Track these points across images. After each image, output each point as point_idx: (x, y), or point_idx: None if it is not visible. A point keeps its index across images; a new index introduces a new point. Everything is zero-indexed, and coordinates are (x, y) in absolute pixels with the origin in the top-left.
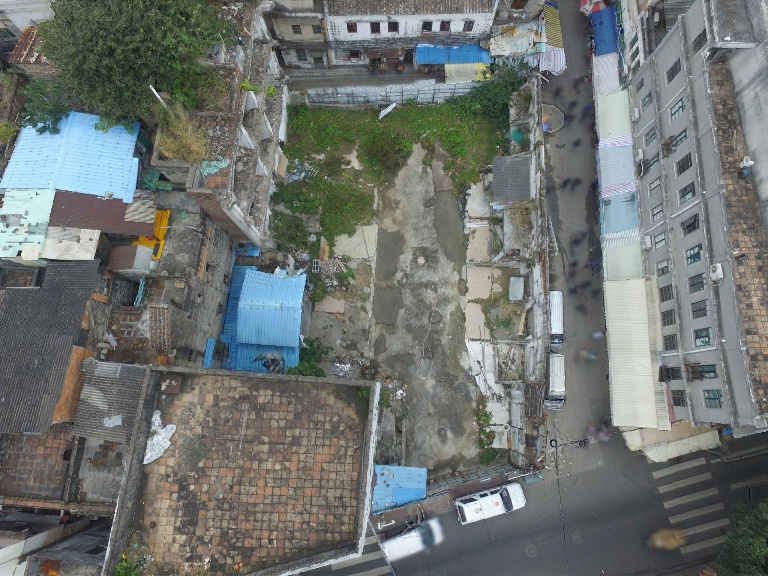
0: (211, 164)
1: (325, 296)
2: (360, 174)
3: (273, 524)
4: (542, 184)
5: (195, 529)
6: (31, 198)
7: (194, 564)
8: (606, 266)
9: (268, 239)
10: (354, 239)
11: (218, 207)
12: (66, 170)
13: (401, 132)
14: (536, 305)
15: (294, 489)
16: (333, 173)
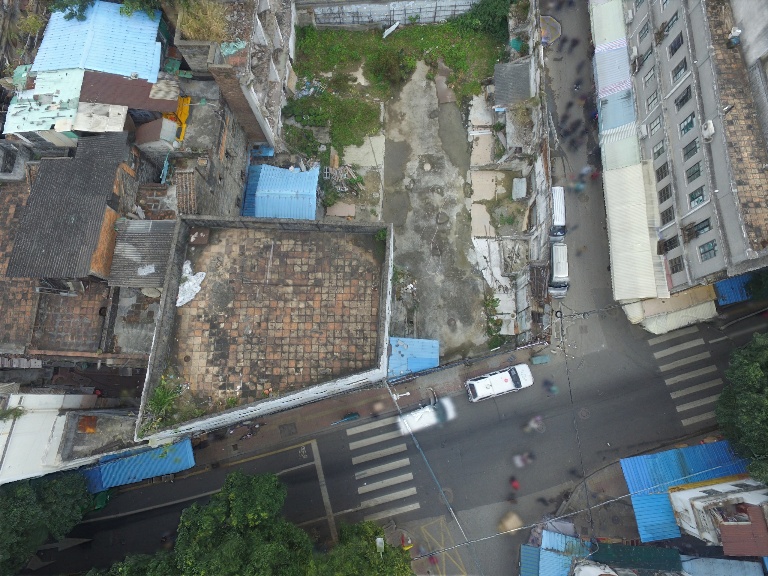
0: (230, 45)
1: (336, 201)
2: (366, 89)
3: (299, 355)
4: (542, 80)
5: (227, 361)
6: (62, 78)
7: (227, 391)
8: (605, 161)
9: (281, 143)
10: (362, 149)
11: (237, 90)
12: (94, 52)
13: (405, 50)
14: (539, 195)
15: (318, 324)
16: (341, 89)
